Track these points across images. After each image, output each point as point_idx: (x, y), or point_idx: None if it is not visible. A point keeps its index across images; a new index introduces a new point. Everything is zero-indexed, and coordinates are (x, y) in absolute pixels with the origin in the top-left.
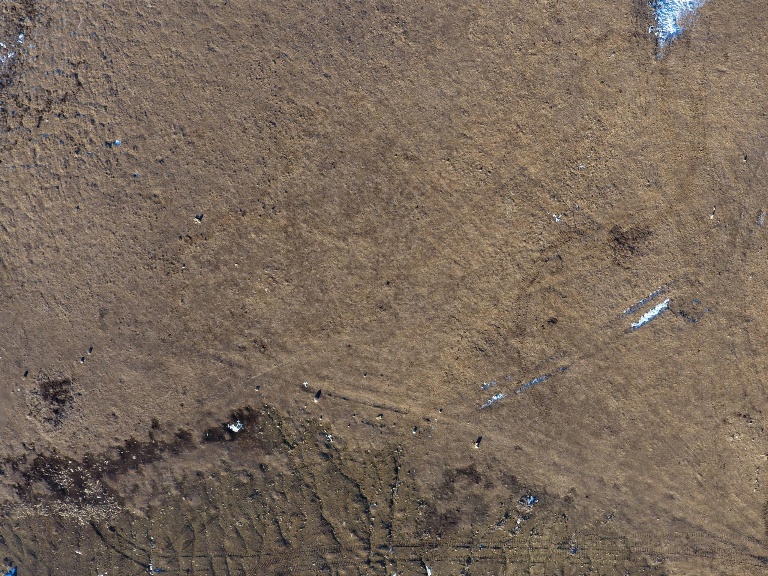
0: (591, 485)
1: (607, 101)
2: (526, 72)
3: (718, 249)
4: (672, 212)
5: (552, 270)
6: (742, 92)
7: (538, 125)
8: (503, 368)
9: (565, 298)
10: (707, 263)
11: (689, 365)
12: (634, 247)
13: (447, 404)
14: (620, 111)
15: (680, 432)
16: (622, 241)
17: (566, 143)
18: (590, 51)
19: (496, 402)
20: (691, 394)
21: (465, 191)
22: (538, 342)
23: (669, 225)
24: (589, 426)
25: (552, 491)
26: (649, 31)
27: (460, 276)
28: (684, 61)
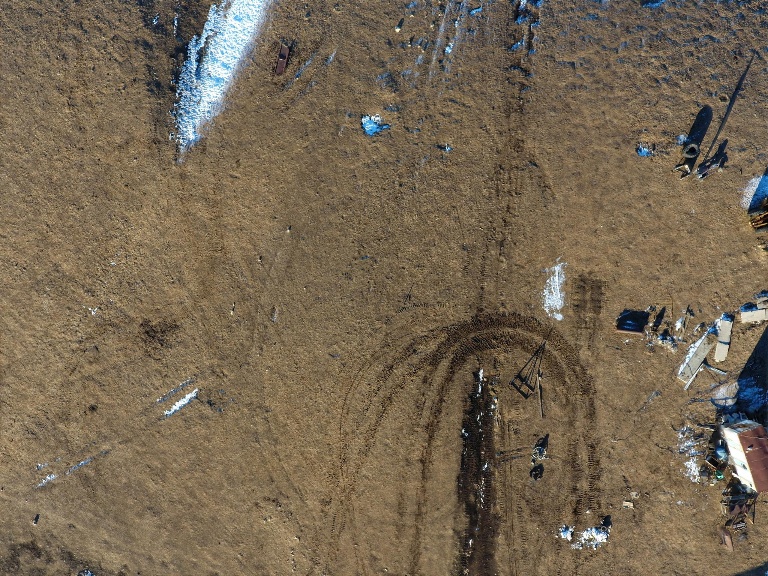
0: (141, 562)
1: (132, 203)
2: (53, 176)
3: (239, 343)
4: (196, 307)
5: (90, 360)
6: (254, 196)
7: (67, 225)
8: (53, 451)
9: (103, 386)
10: (230, 356)
11: (219, 452)
12: (163, 340)
13: (8, 483)
14: (145, 212)
15: (218, 514)
16: (152, 334)
17: (96, 242)
18: (112, 157)
19: (49, 482)
20: (223, 479)
21: (3, 286)
22: (82, 427)
23: (194, 320)
24: (133, 507)
25: (107, 567)
26: (169, 138)
27: (6, 364)
28: (200, 167)
